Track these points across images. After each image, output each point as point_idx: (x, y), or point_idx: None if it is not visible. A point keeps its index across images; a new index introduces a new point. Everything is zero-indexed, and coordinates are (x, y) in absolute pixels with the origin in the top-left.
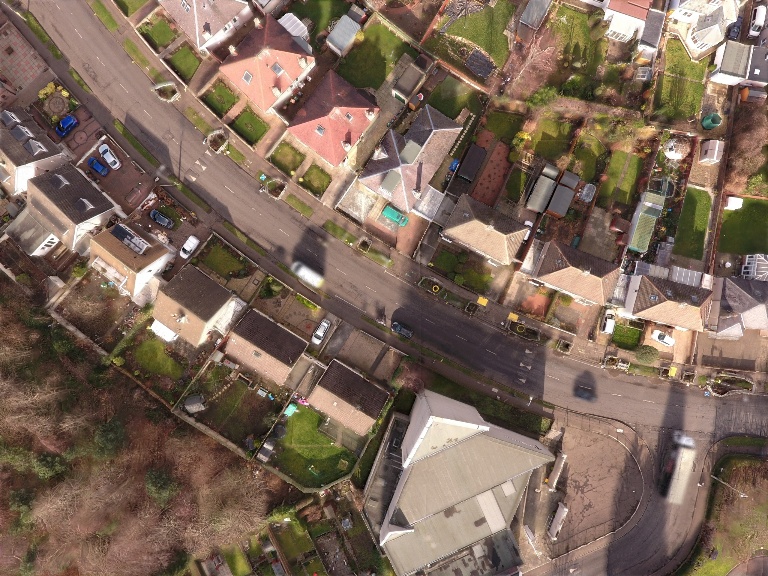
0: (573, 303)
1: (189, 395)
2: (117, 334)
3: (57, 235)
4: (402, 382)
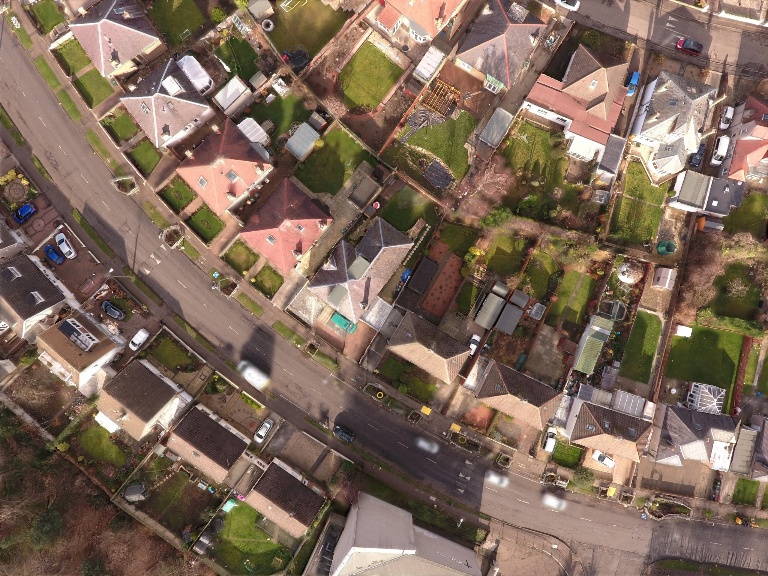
0: None
1: (130, 483)
2: (64, 419)
3: (8, 323)
4: (339, 488)
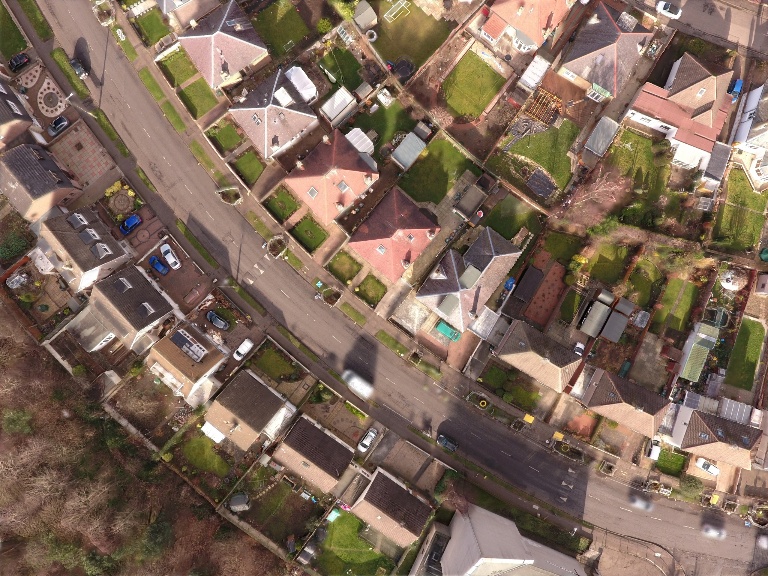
0: (619, 426)
1: (234, 493)
2: (167, 429)
3: (116, 334)
4: (445, 498)
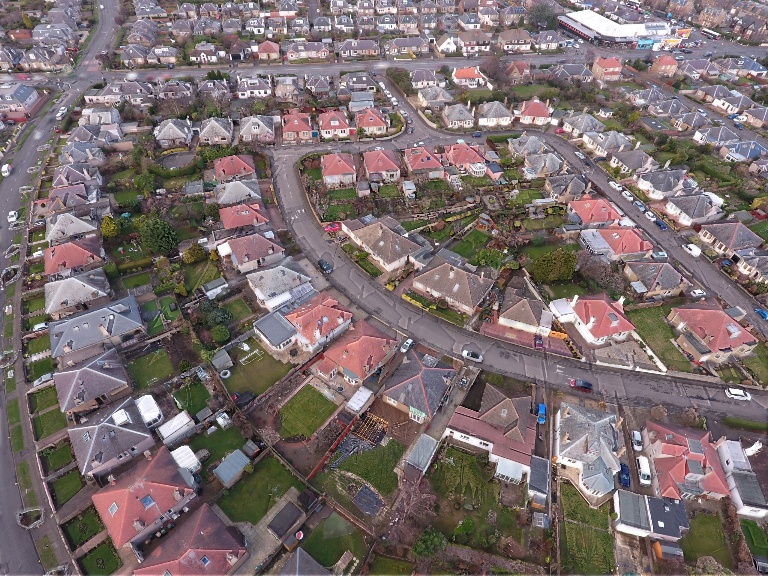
0: None
1: None
2: None
3: None
4: None
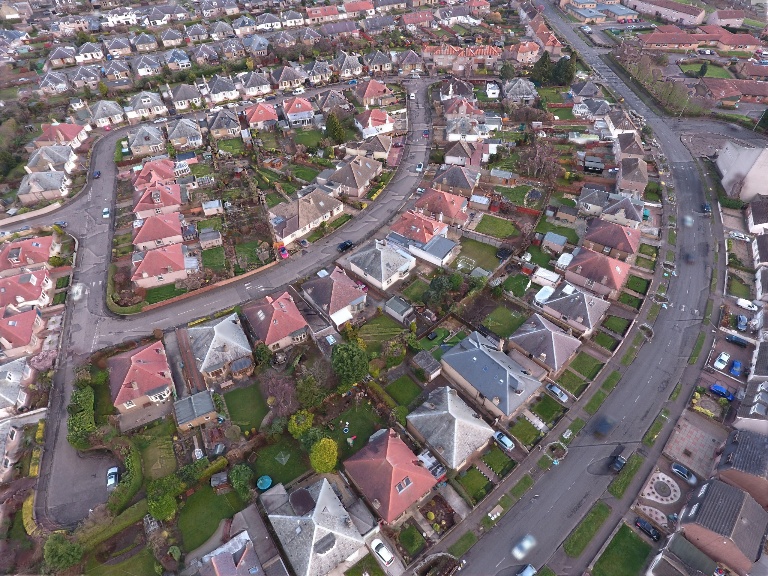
0: None
1: None
2: None
3: None
4: (739, 198)
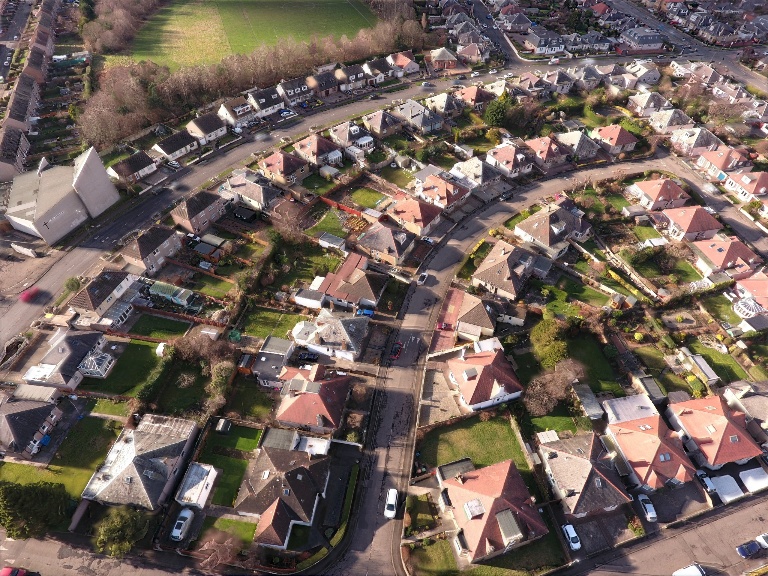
0: None
1: None
2: None
3: None
4: (127, 182)
